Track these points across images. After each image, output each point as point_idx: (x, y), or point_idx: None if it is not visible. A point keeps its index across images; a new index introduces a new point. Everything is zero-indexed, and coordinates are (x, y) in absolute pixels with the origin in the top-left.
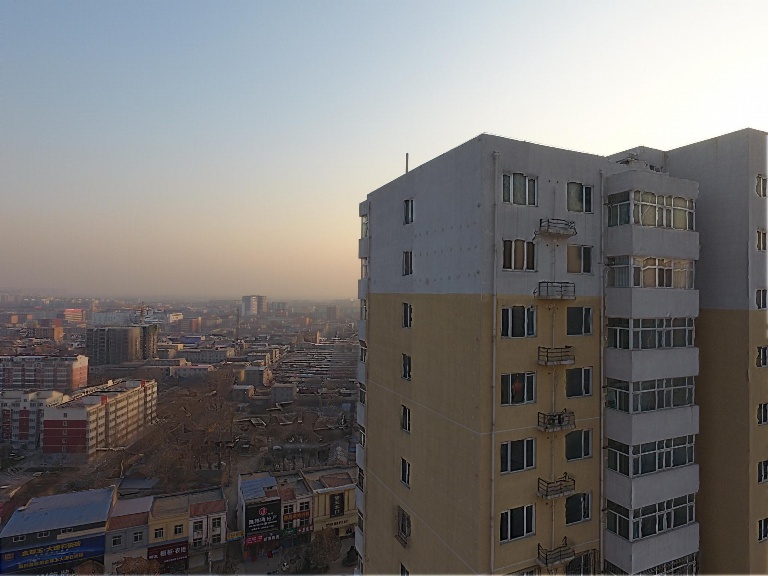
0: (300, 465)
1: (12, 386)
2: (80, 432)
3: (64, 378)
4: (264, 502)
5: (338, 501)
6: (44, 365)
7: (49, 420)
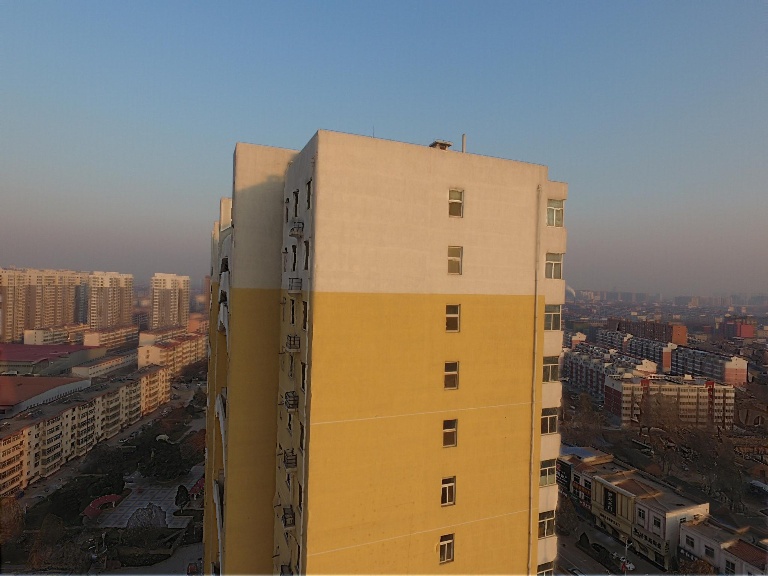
0: (750, 508)
1: (687, 373)
2: (619, 401)
3: (718, 375)
4: (560, 460)
5: (611, 498)
6: (706, 360)
7: (607, 386)
